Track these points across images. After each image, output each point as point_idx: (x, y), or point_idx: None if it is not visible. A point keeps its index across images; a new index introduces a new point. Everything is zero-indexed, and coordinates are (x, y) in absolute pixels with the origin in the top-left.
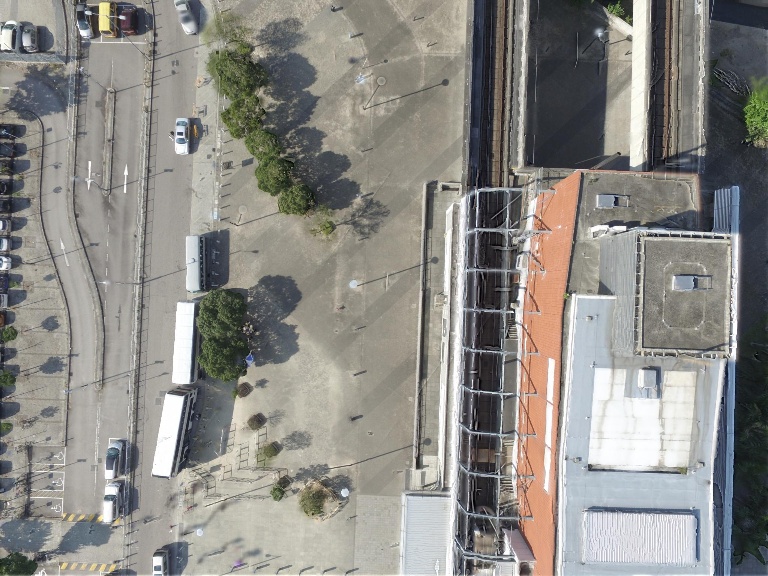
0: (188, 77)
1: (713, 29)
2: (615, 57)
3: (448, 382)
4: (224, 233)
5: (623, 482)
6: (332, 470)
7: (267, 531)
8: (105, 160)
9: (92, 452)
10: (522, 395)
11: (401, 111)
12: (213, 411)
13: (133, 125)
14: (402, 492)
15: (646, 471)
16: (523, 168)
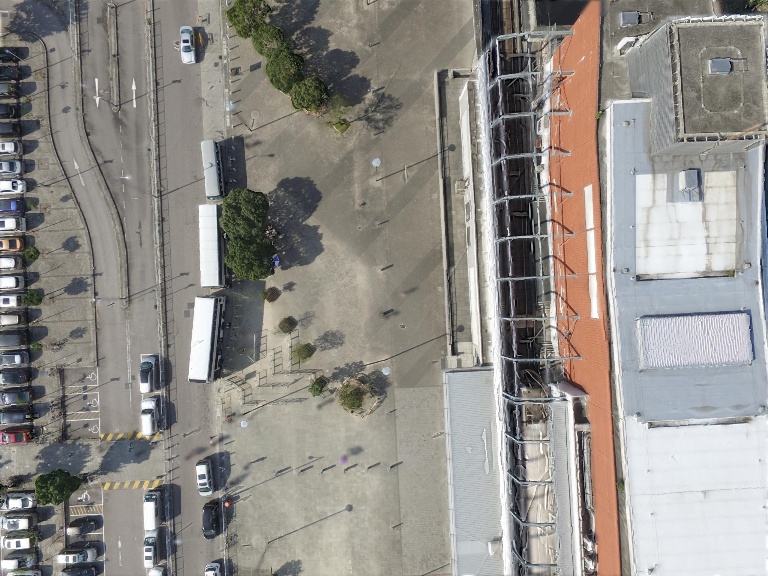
0: None
1: None
2: None
3: (478, 259)
4: (238, 140)
5: (672, 289)
6: (367, 366)
7: (308, 433)
8: (112, 76)
9: (125, 370)
10: (556, 250)
11: (405, 3)
12: (243, 318)
13: (137, 39)
14: (442, 370)
15: (694, 277)
16: (536, 29)
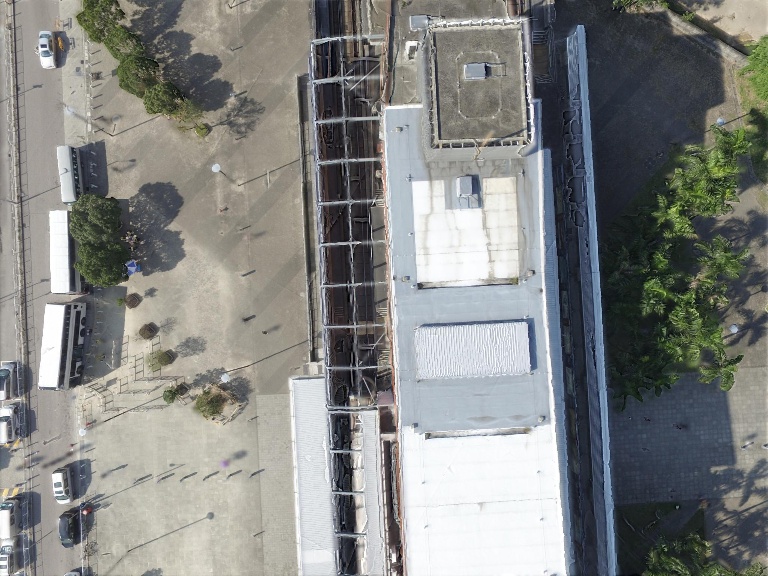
0: None
1: None
2: None
3: None
4: (99, 145)
5: (454, 297)
6: (229, 373)
7: (169, 440)
8: None
9: None
10: None
11: (268, 6)
12: (104, 325)
13: None
14: None
15: (477, 285)
16: (373, 32)
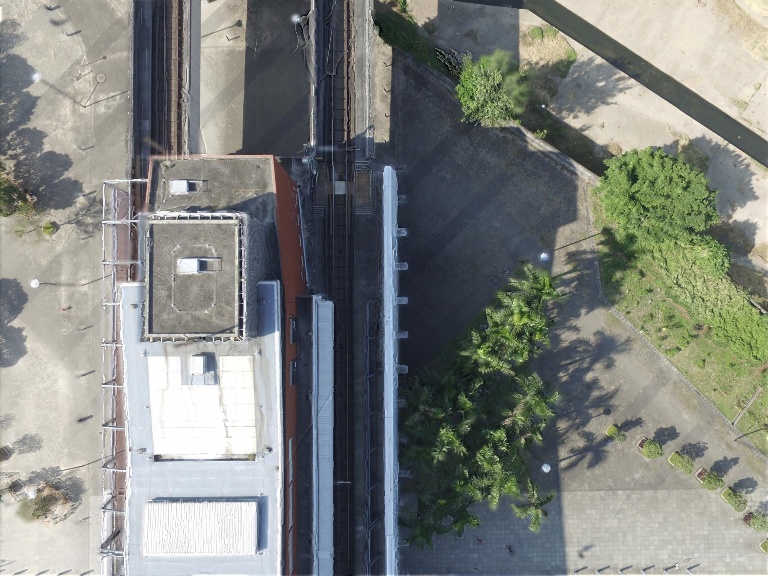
0: None
1: (457, 10)
2: None
3: None
4: None
5: (189, 471)
6: (64, 472)
7: (2, 536)
8: None
9: None
10: None
11: (121, 107)
12: None
13: None
14: (104, 491)
15: (215, 459)
16: (191, 158)
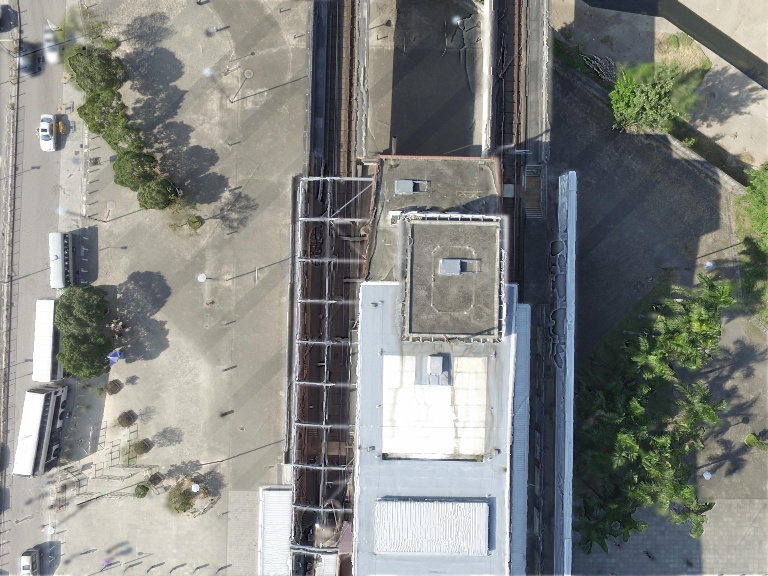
0: (54, 73)
1: (593, 16)
2: (470, 44)
3: None
4: (92, 230)
5: (418, 471)
6: (204, 466)
7: (139, 529)
8: None
9: None
10: None
11: (269, 104)
12: (84, 409)
13: None
14: (259, 487)
15: (442, 459)
16: (366, 157)
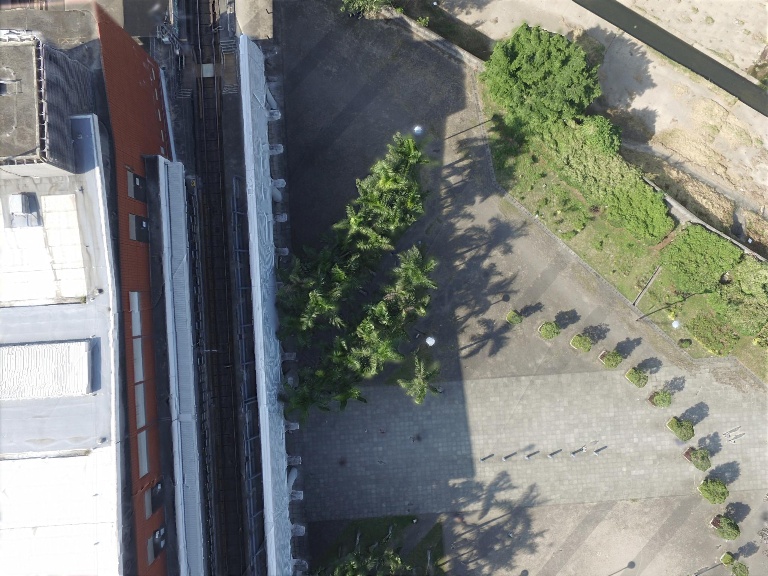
0: None
1: None
2: None
3: None
4: None
5: (19, 317)
6: None
7: None
8: None
9: None
10: None
11: None
12: None
13: None
14: None
15: (46, 304)
16: None
